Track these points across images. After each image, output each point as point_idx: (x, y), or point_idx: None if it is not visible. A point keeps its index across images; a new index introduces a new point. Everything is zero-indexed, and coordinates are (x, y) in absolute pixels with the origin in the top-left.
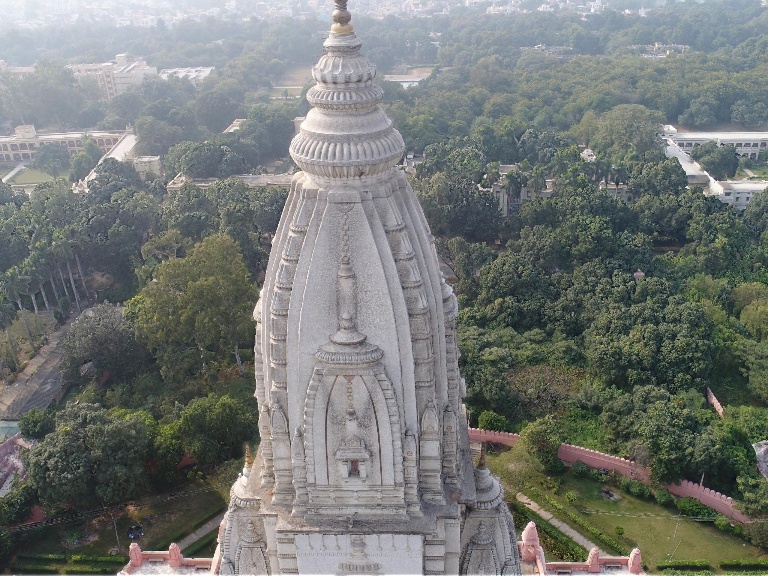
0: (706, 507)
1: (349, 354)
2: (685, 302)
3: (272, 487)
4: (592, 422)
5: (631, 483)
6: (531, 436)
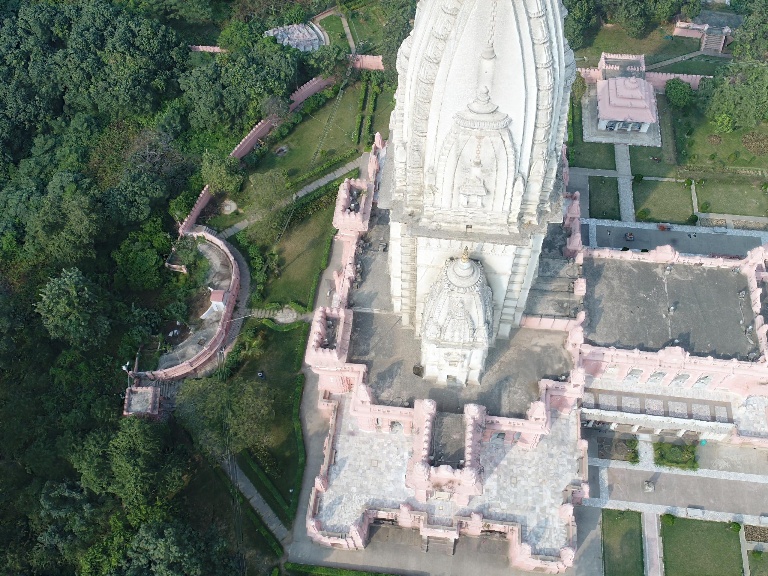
0: (315, 96)
1: (573, 64)
2: (78, 6)
3: (522, 224)
4: (196, 137)
5: (280, 131)
6: (227, 173)
